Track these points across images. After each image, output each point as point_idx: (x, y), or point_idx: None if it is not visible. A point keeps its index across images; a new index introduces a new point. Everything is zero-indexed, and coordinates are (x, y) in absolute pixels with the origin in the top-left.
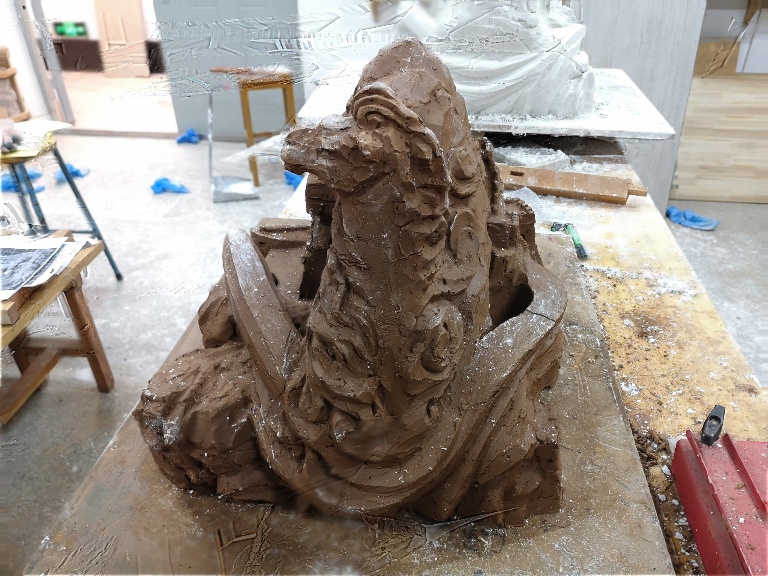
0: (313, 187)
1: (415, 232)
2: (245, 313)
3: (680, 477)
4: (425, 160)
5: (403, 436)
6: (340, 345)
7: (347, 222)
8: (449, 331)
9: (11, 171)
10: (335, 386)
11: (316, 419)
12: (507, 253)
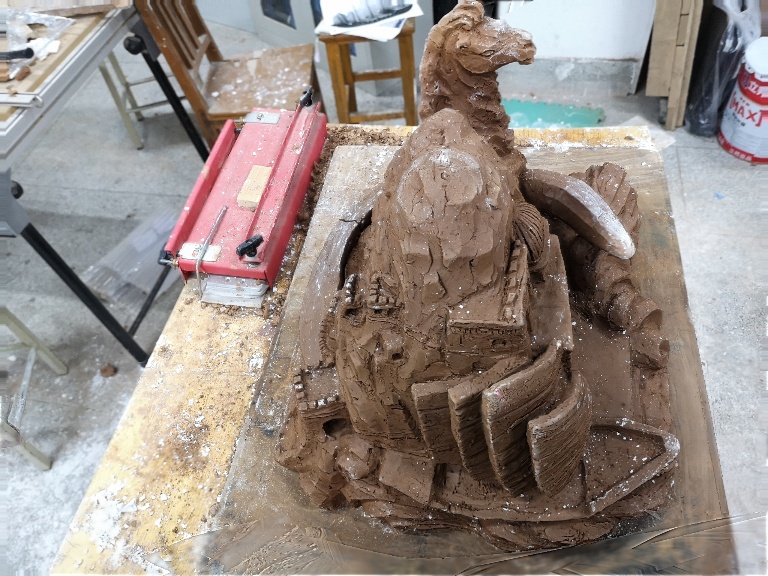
0: None
1: None
2: None
3: None
4: None
5: None
6: None
7: None
8: None
9: None
10: None
11: None
12: None
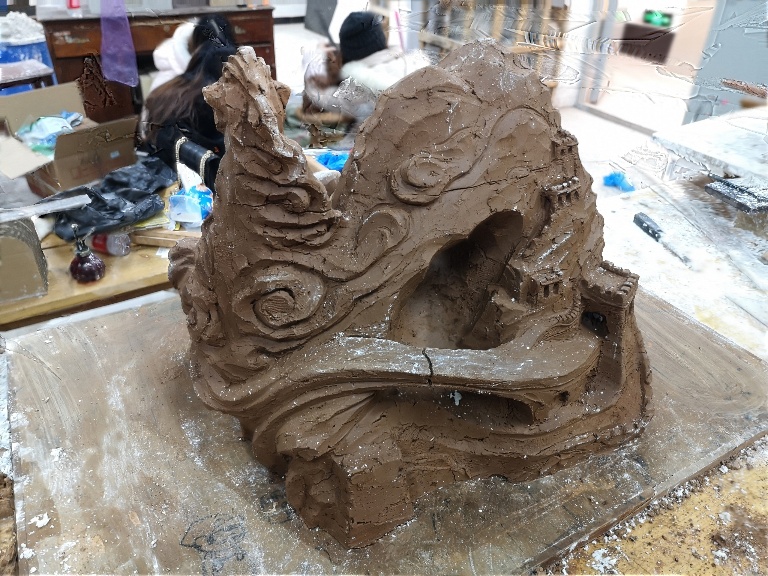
0: None
1: (246, 185)
2: None
3: None
4: None
5: (229, 358)
6: (196, 251)
7: None
8: (296, 301)
9: None
10: None
11: None
12: (511, 305)
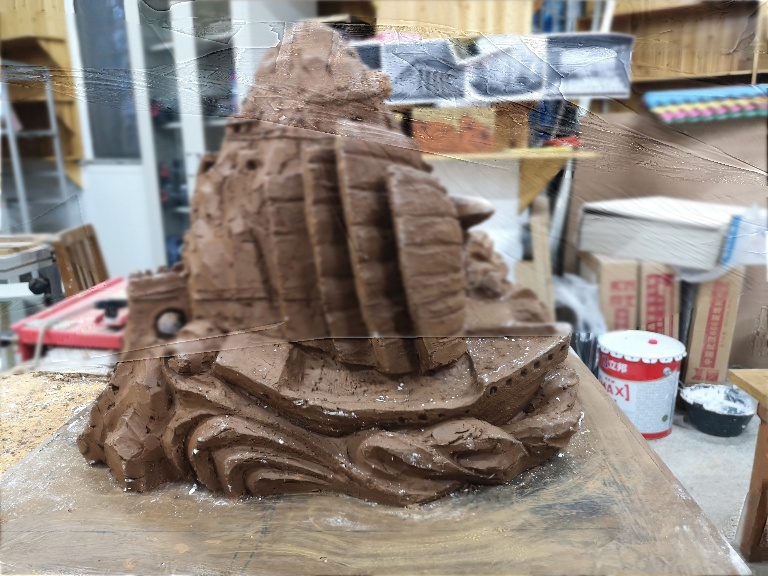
0: None
1: None
2: None
3: None
4: None
5: None
6: None
7: None
8: None
9: None
10: None
11: None
12: None
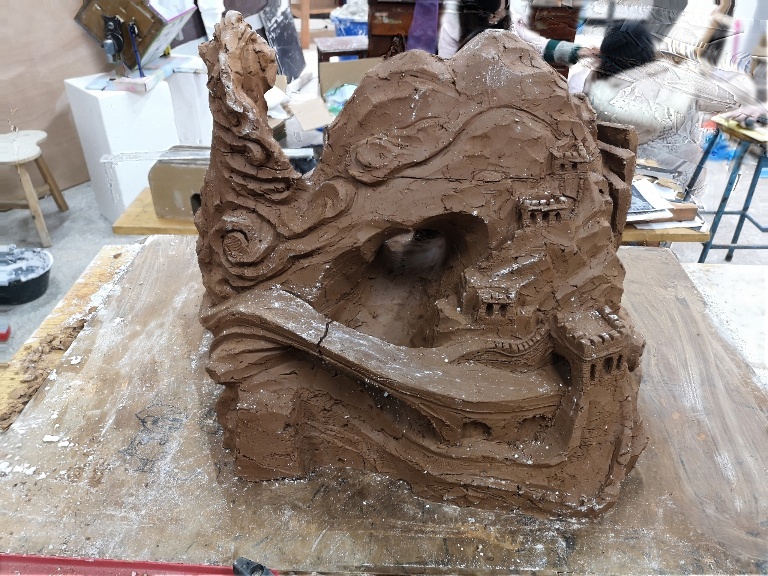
0: None
1: None
2: None
3: None
4: None
5: None
6: None
7: None
8: (249, 245)
9: (735, 145)
10: None
11: None
12: (452, 313)
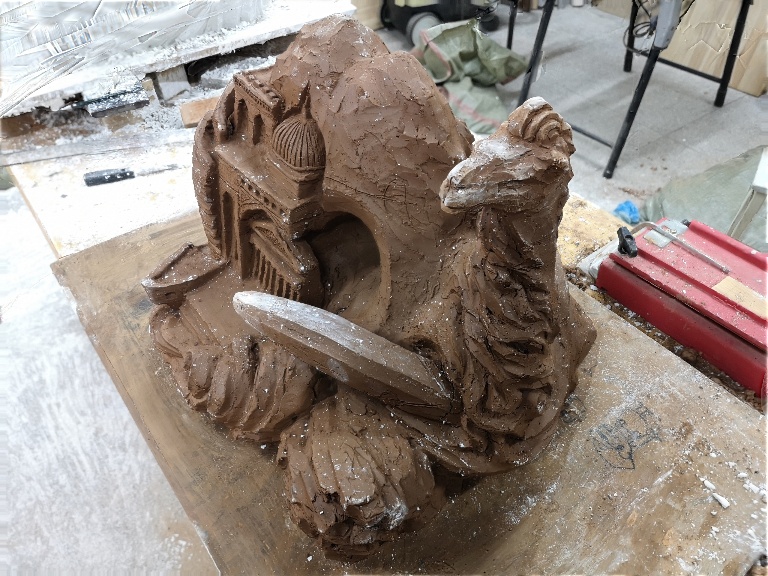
0: (297, 210)
1: None
2: (370, 368)
3: (612, 287)
4: (573, 151)
5: None
6: (538, 339)
7: (523, 235)
8: None
9: None
10: (540, 373)
11: (514, 409)
12: None
